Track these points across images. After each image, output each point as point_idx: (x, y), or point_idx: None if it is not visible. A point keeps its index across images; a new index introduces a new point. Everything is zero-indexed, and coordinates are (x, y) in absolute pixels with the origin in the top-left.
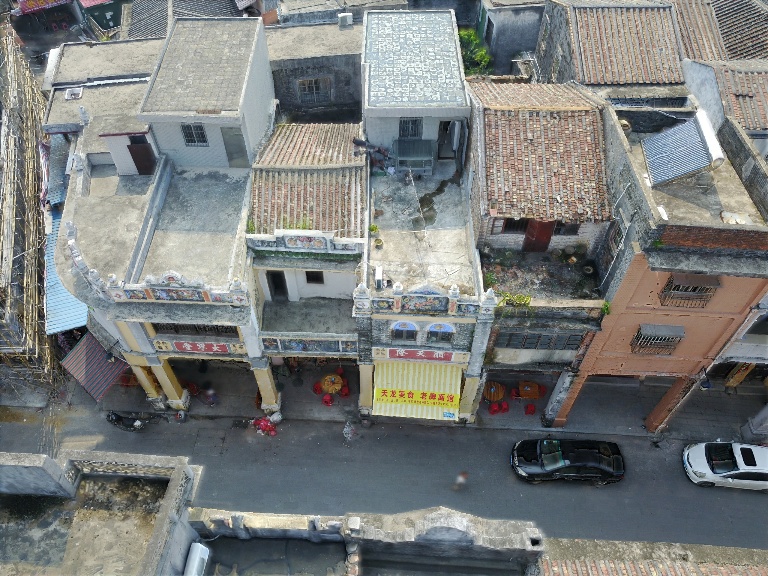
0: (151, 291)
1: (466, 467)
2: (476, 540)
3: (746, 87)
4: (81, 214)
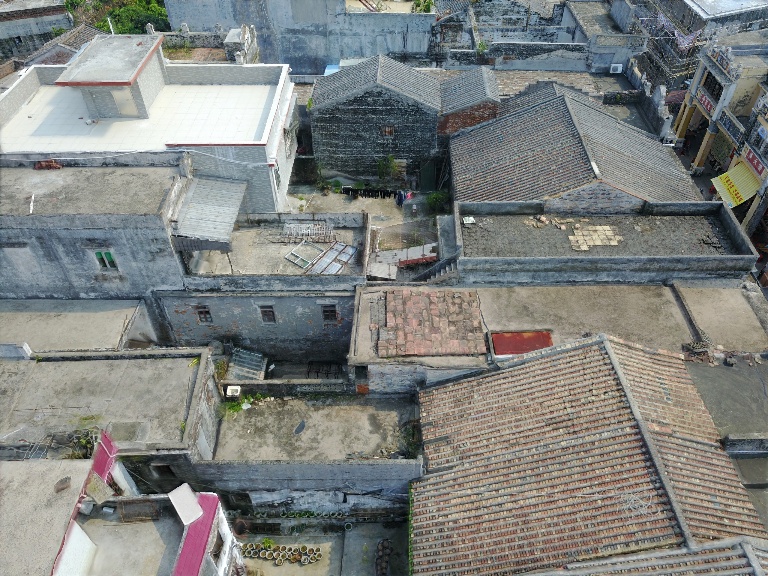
0: (718, 55)
1: None
2: None
3: None
4: (746, 33)
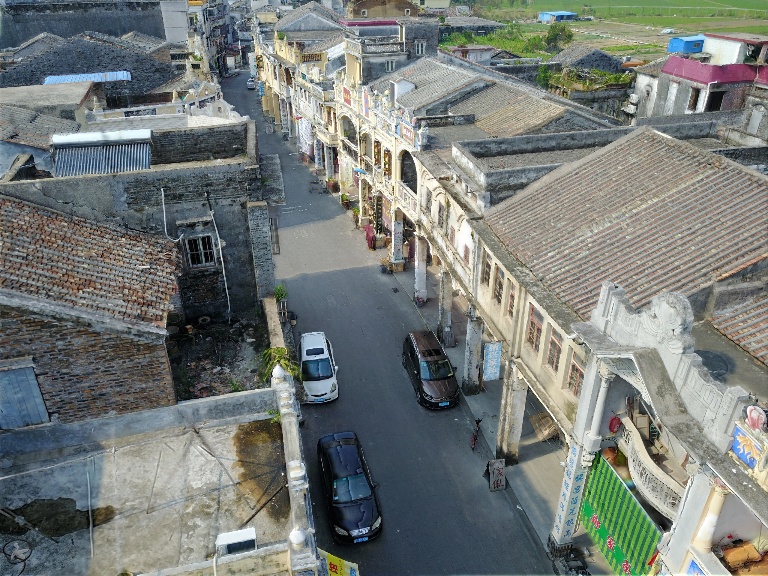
0: None
1: None
2: None
3: (1, 131)
4: None
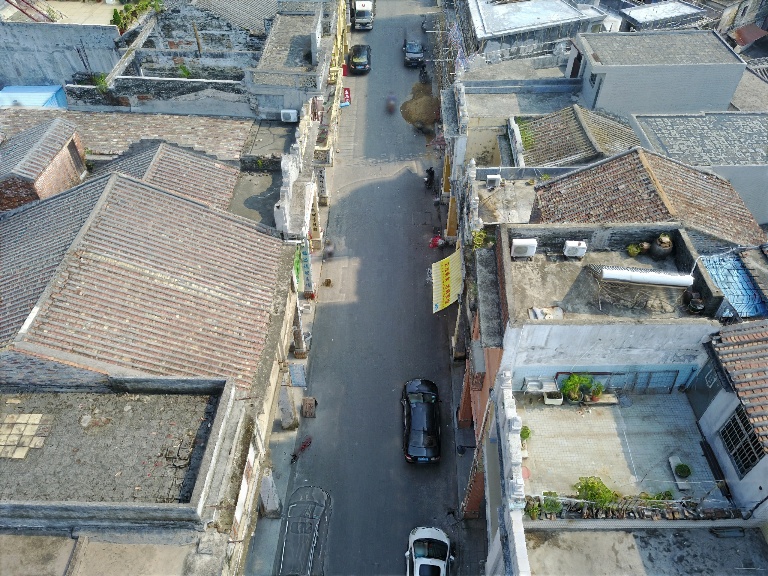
0: None
1: (415, 355)
2: (283, 187)
3: None
4: (514, 62)
